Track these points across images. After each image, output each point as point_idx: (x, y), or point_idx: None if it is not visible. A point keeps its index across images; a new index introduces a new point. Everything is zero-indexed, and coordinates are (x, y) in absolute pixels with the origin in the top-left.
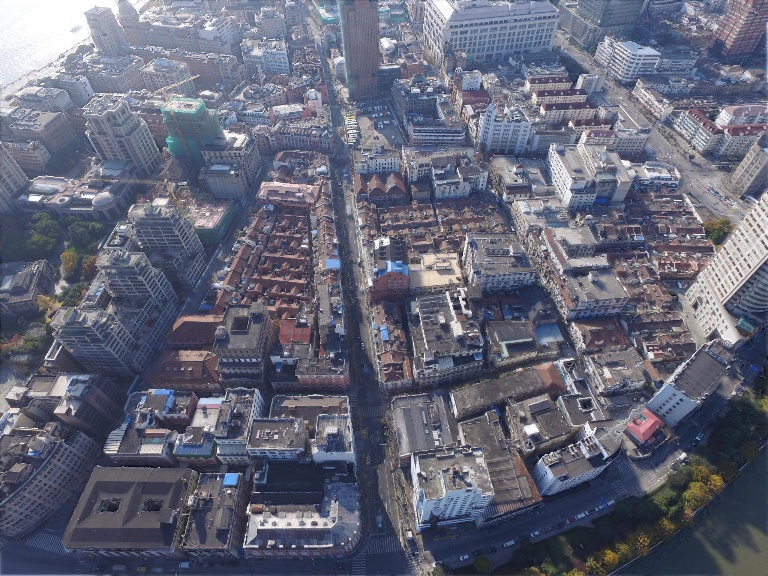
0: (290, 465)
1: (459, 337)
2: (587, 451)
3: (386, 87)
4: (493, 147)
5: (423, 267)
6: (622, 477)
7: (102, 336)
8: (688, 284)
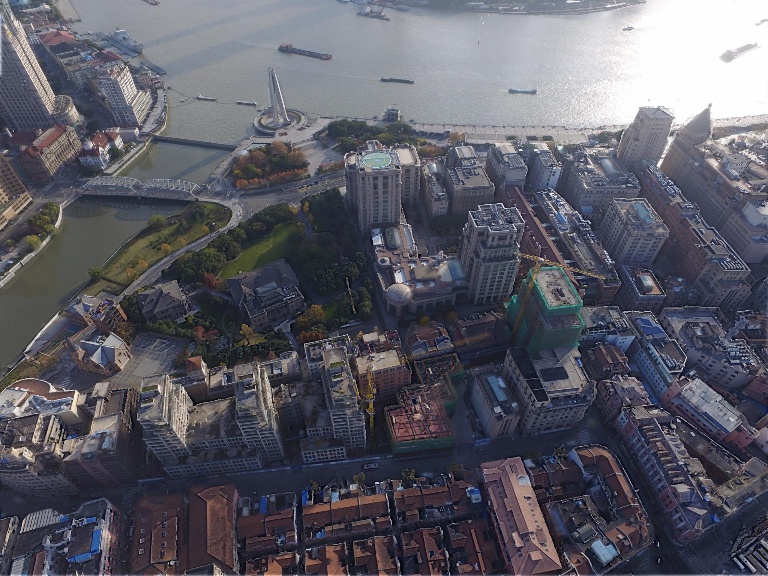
0: None
1: None
2: None
3: None
4: None
5: None
6: None
7: (149, 431)
8: None
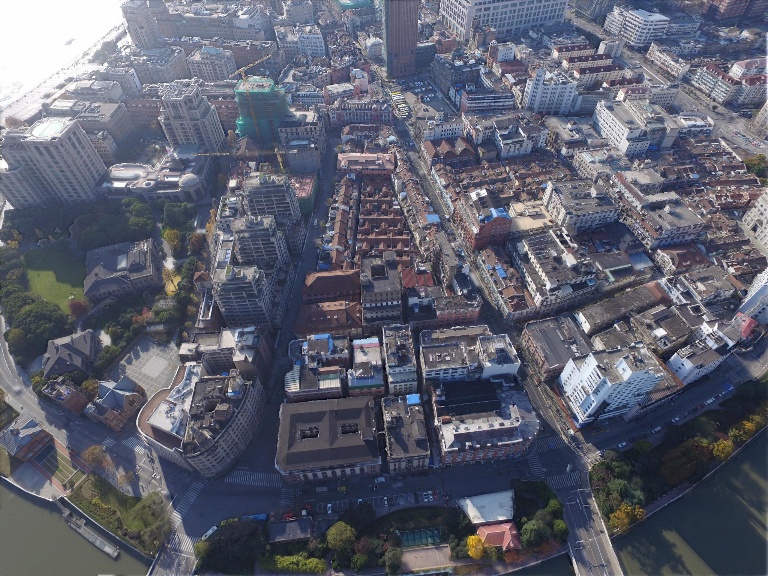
0: (460, 383)
1: (573, 266)
2: (714, 342)
3: (422, 64)
4: (540, 110)
5: (514, 215)
6: (733, 369)
7: (257, 291)
8: (743, 212)
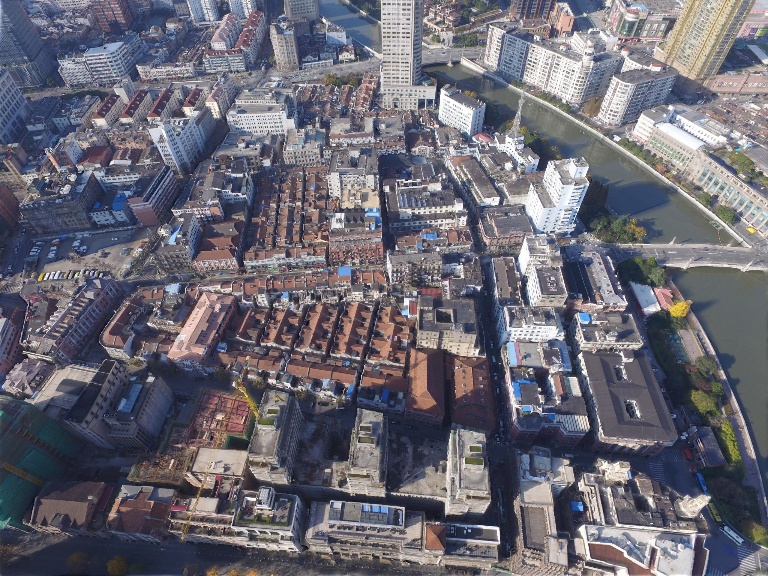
0: None
1: (441, 188)
2: (522, 144)
3: None
4: (190, 160)
5: None
6: None
7: None
8: (376, 104)
